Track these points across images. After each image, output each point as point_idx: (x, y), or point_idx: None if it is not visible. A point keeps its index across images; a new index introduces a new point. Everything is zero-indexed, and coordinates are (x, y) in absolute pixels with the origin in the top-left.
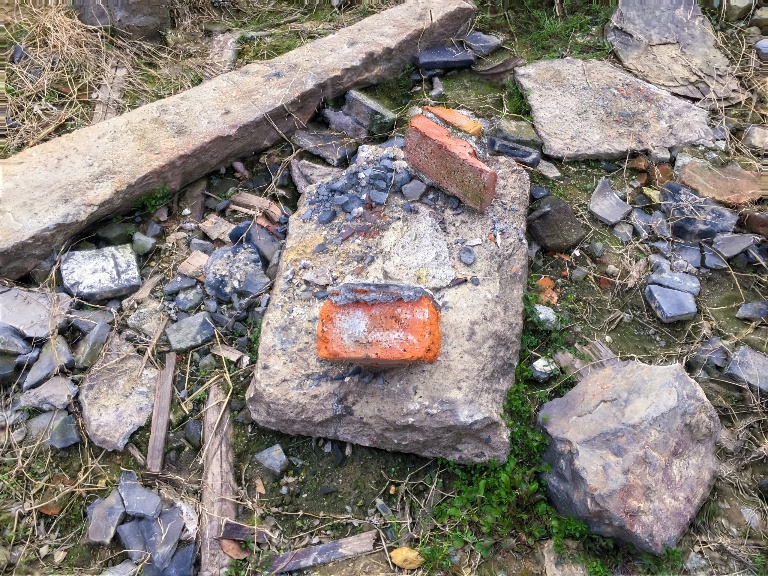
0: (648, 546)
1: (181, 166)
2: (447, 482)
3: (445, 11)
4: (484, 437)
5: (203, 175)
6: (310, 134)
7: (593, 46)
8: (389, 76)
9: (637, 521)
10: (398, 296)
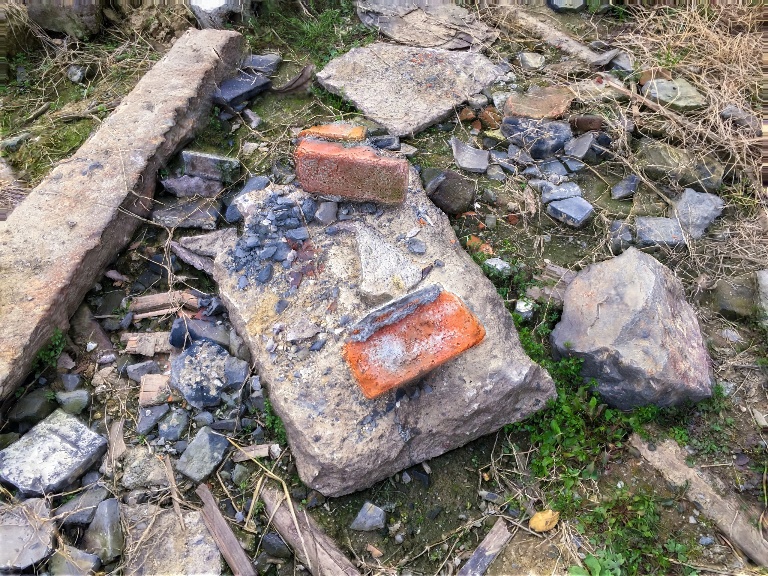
0: (699, 391)
1: (65, 300)
2: (519, 443)
3: (221, 45)
4: (534, 385)
5: (80, 301)
6: (168, 210)
7: (359, 33)
8: (202, 125)
9: (687, 376)
10: (424, 300)
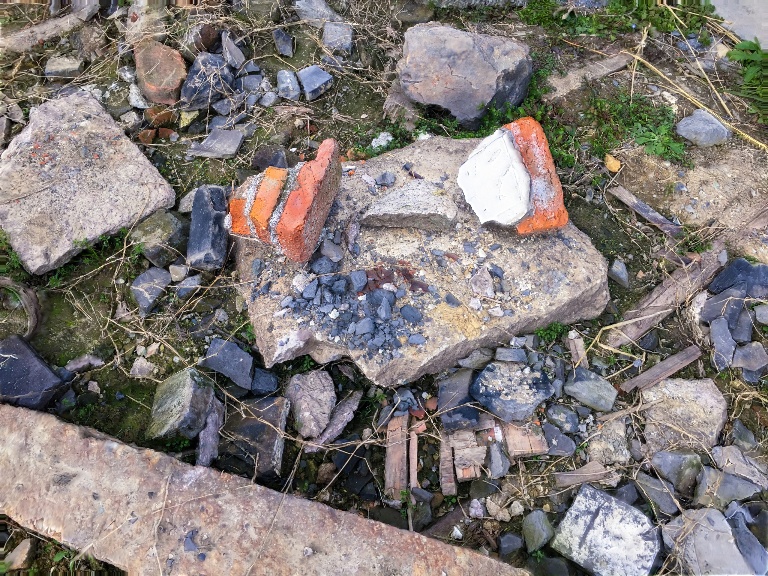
0: None
1: None
2: None
3: None
4: None
5: None
6: None
7: None
8: None
9: None
10: None
